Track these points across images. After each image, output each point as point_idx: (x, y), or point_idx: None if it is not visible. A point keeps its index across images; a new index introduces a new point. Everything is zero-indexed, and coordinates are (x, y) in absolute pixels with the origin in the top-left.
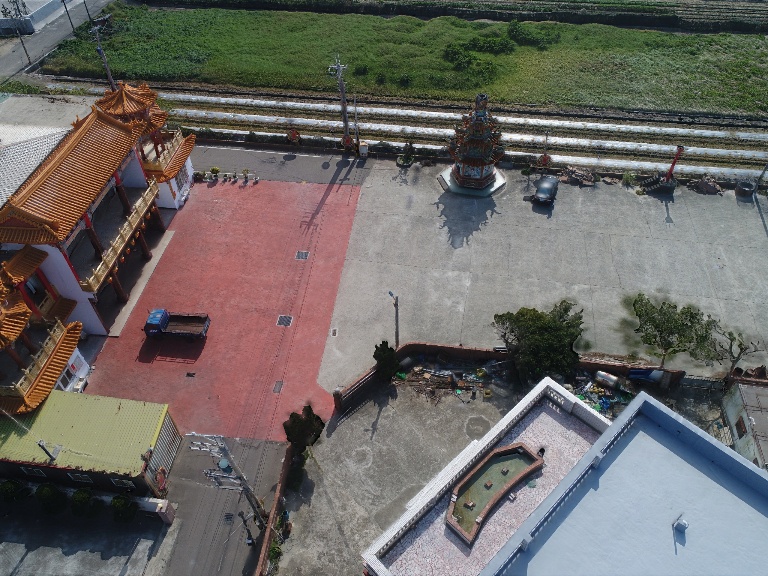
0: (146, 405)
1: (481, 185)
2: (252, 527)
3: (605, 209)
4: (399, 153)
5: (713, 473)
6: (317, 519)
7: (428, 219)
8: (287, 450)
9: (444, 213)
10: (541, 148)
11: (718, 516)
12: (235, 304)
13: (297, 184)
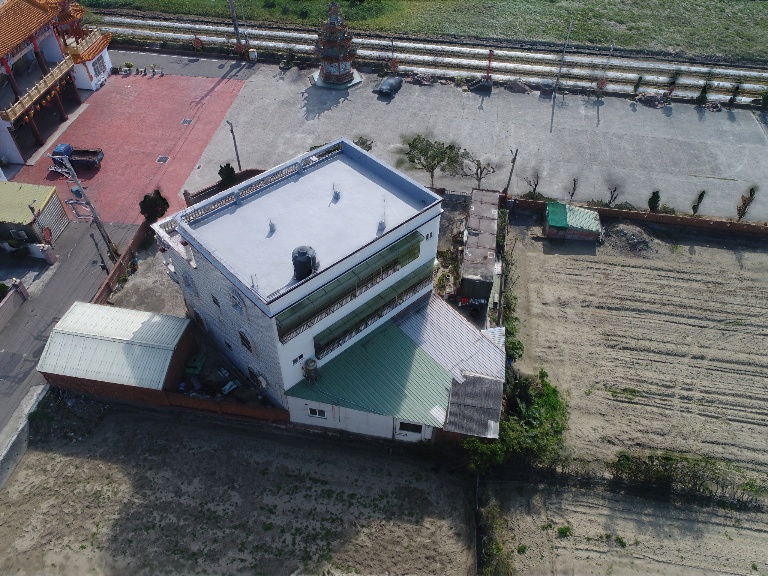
0: (40, 187)
1: (340, 81)
2: (110, 267)
3: (434, 100)
4: (282, 59)
5: (372, 177)
6: (157, 264)
7: (292, 102)
8: (142, 223)
9: (306, 99)
10: (402, 62)
11: (364, 193)
12: (127, 149)
13: (195, 78)
